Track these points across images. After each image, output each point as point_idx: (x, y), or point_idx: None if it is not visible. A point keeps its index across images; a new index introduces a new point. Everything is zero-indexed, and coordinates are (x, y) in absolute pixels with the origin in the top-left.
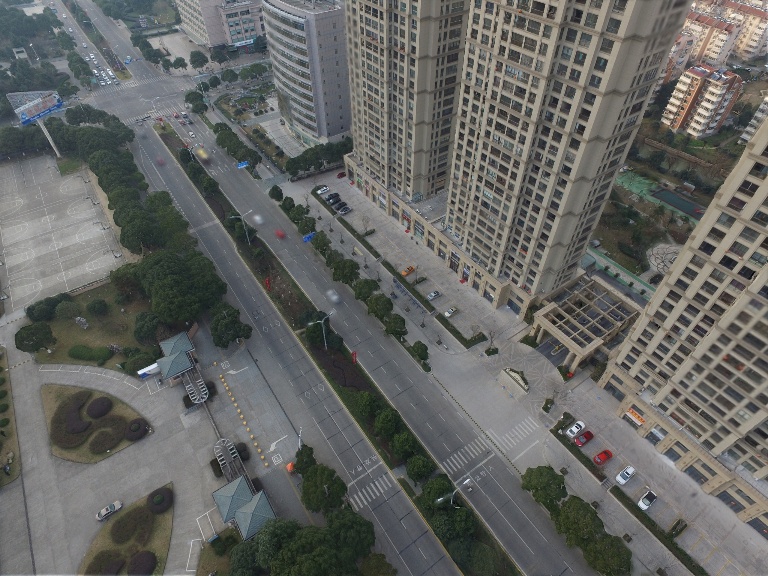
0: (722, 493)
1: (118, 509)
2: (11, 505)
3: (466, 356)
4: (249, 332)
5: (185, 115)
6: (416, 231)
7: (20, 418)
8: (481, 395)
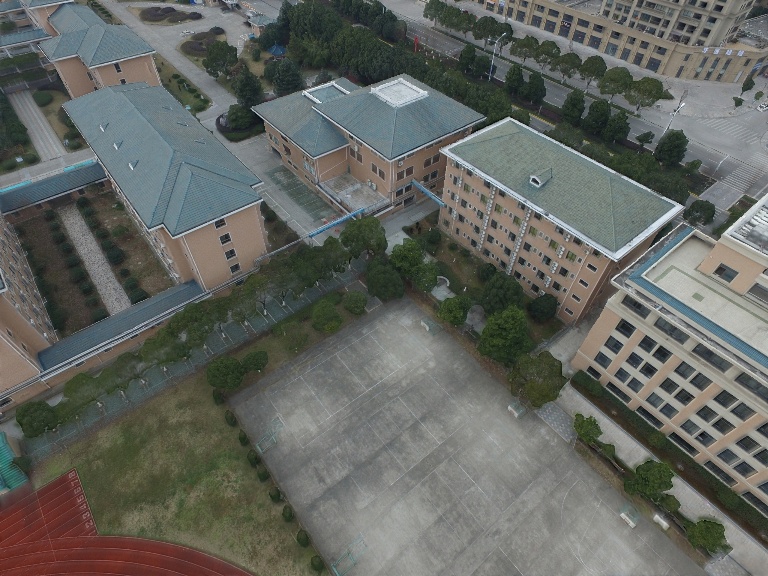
0: (533, 20)
1: (193, 33)
2: None
3: None
4: None
5: None
6: None
7: (118, 15)
8: (405, 7)
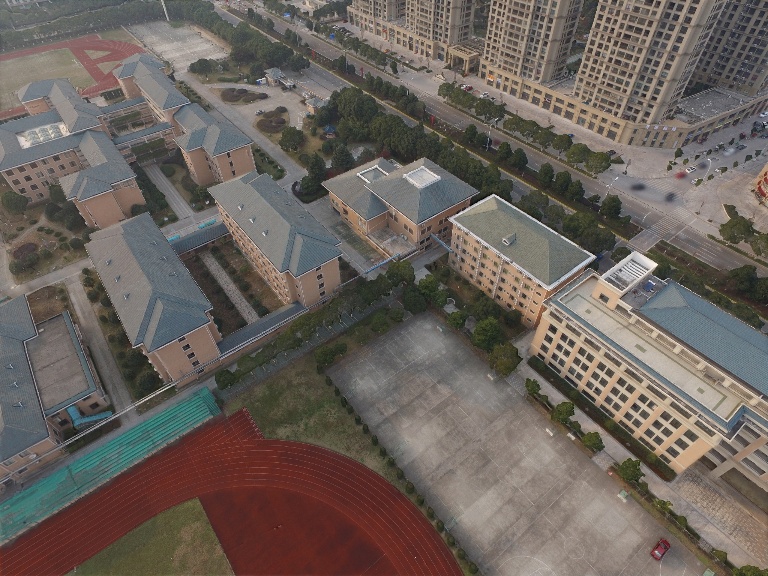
0: (523, 95)
1: (263, 112)
2: (215, 114)
3: (417, 74)
4: (309, 64)
5: (240, 2)
6: (390, 37)
7: (204, 96)
8: (423, 83)
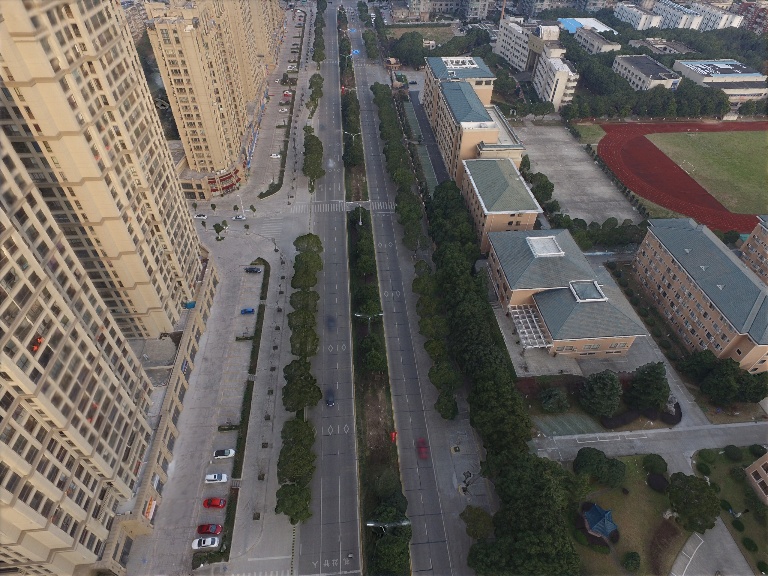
0: None
1: None
2: None
3: None
4: None
5: None
6: None
7: None
8: None
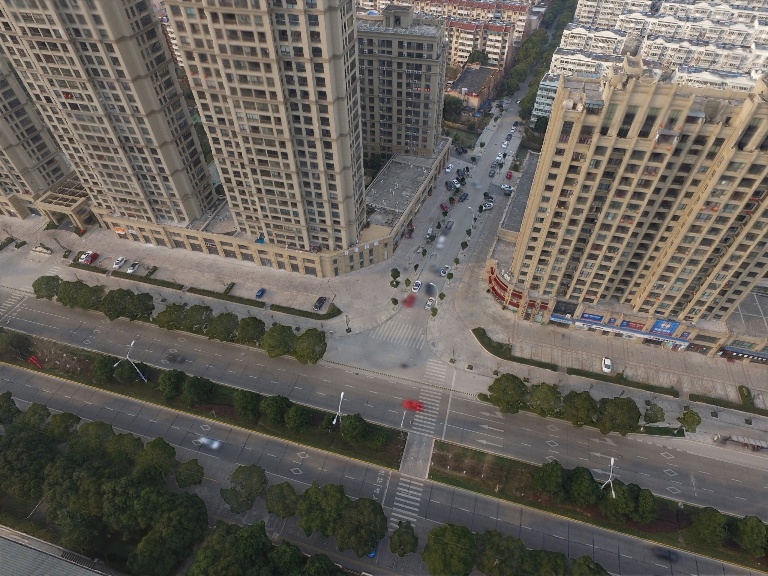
0: (175, 243)
1: None
2: None
3: None
4: None
5: None
6: None
7: None
8: (14, 272)
